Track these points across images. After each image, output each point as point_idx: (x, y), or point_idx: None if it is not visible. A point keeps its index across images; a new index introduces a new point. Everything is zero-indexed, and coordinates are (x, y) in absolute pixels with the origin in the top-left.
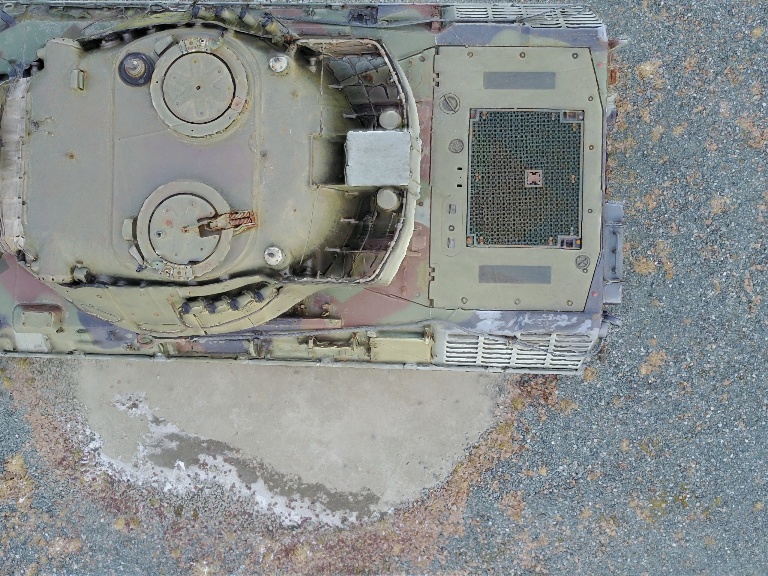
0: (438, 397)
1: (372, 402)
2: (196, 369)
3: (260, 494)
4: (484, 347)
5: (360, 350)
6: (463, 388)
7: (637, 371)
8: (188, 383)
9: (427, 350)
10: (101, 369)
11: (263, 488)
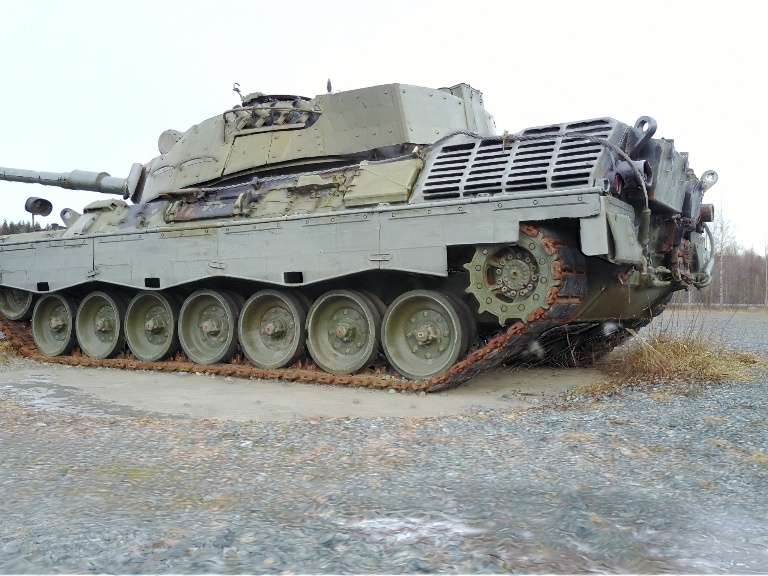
0: (388, 404)
1: (292, 396)
2: (134, 375)
3: (46, 400)
4: (476, 158)
5: (340, 198)
6: (433, 406)
7: (761, 402)
8: (112, 376)
9: (410, 173)
10: (53, 370)
11: (58, 399)
